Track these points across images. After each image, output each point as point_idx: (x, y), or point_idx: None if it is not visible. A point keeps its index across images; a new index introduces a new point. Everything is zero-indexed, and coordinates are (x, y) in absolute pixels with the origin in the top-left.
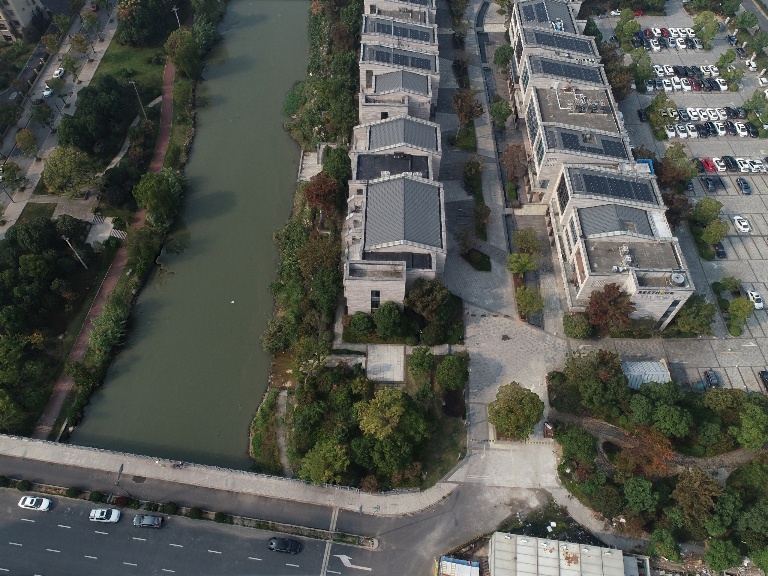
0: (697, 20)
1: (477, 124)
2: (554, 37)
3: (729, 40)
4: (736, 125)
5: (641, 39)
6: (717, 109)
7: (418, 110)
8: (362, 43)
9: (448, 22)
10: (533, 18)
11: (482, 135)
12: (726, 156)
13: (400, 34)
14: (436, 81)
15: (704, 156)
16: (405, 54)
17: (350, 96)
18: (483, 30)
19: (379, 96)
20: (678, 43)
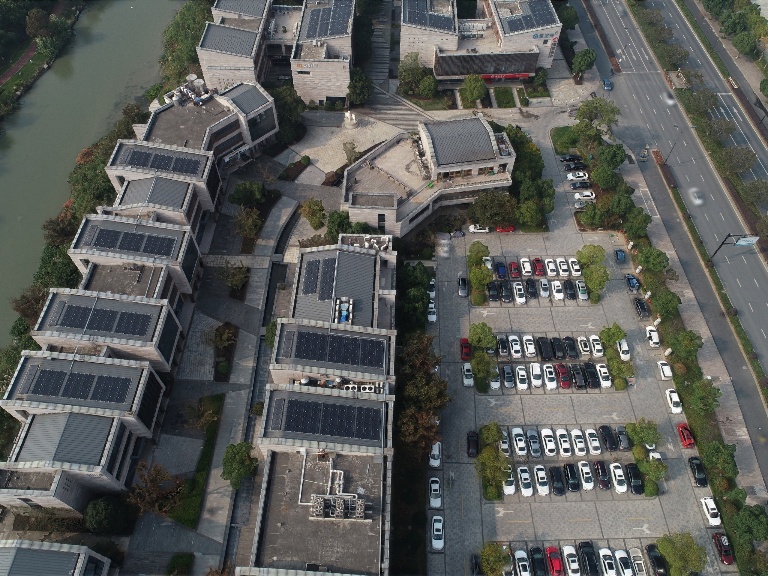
0: (582, 256)
1: (216, 461)
2: (329, 338)
3: (628, 284)
4: (611, 470)
5: (500, 283)
6: (588, 433)
7: (91, 478)
8: (22, 356)
9: (237, 243)
10: (313, 289)
11: (217, 487)
12: (584, 546)
13: (99, 326)
14: (132, 421)
15: (553, 538)
16: (91, 371)
17: (5, 435)
18: (282, 259)
19: (18, 468)
20: (553, 290)
